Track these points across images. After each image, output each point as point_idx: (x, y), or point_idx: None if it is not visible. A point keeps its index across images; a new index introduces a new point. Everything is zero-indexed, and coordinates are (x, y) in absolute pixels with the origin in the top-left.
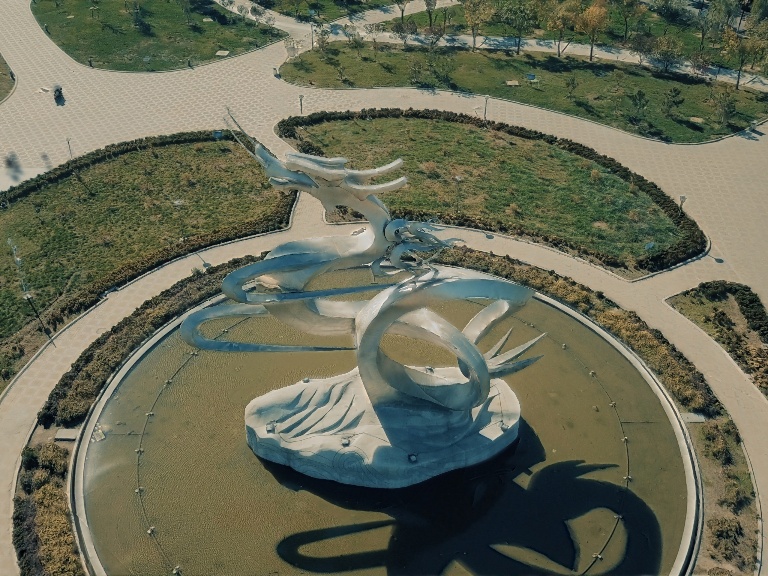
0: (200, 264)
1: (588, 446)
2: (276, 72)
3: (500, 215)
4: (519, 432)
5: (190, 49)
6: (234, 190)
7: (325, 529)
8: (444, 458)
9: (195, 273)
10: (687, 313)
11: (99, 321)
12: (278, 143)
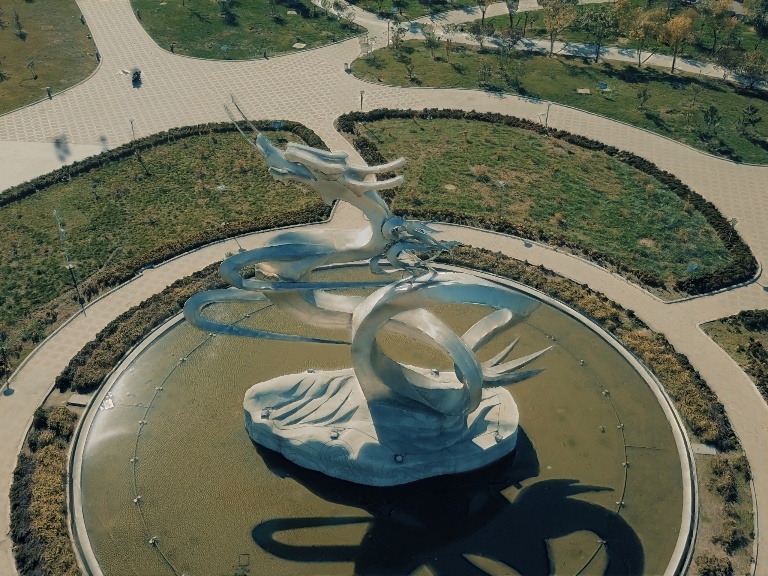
0: (236, 249)
1: (586, 466)
2: (347, 67)
3: (543, 224)
4: (517, 444)
5: (269, 40)
6: None
7: (303, 518)
8: (432, 462)
9: None
10: (720, 341)
11: (130, 295)
12: (335, 137)
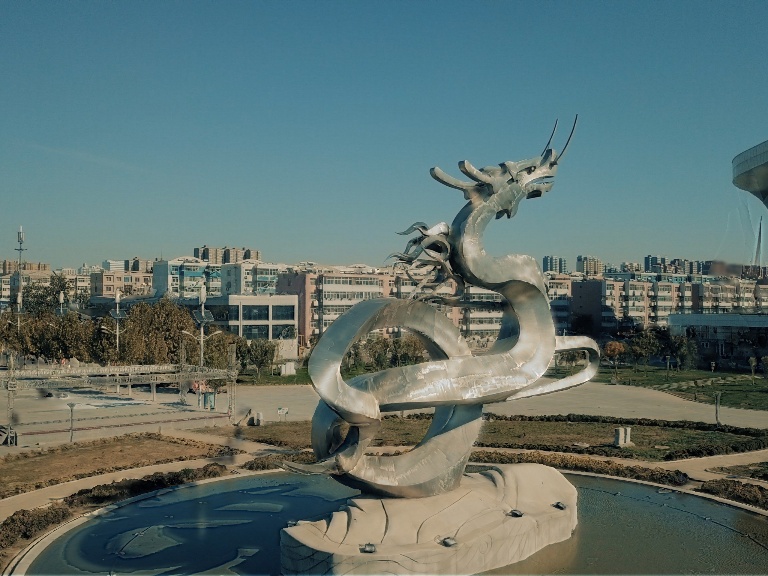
0: None
1: None
2: None
3: None
4: (281, 574)
5: None
6: None
7: None
8: None
9: None
10: None
11: None
12: None
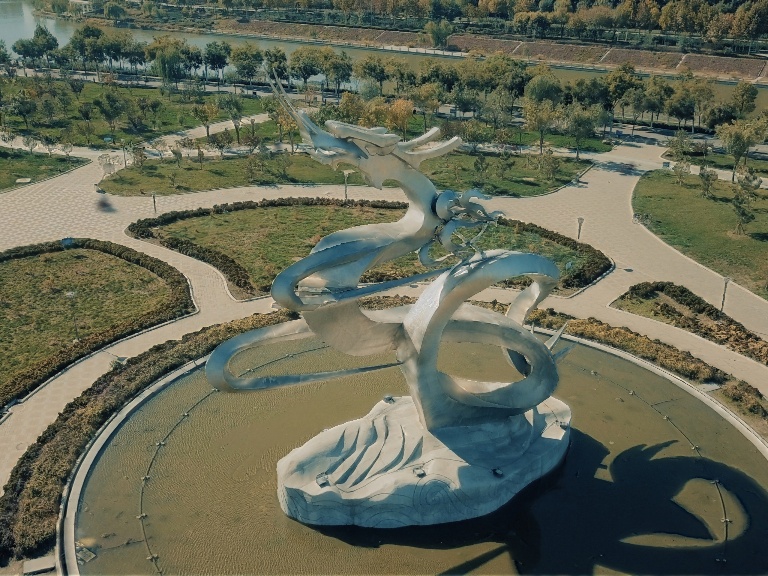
0: (113, 359)
1: (638, 432)
2: (98, 188)
3: (411, 268)
4: None
5: None
6: (112, 289)
7: (437, 575)
8: (524, 468)
9: (116, 366)
10: (635, 312)
11: (13, 437)
12: (137, 244)
